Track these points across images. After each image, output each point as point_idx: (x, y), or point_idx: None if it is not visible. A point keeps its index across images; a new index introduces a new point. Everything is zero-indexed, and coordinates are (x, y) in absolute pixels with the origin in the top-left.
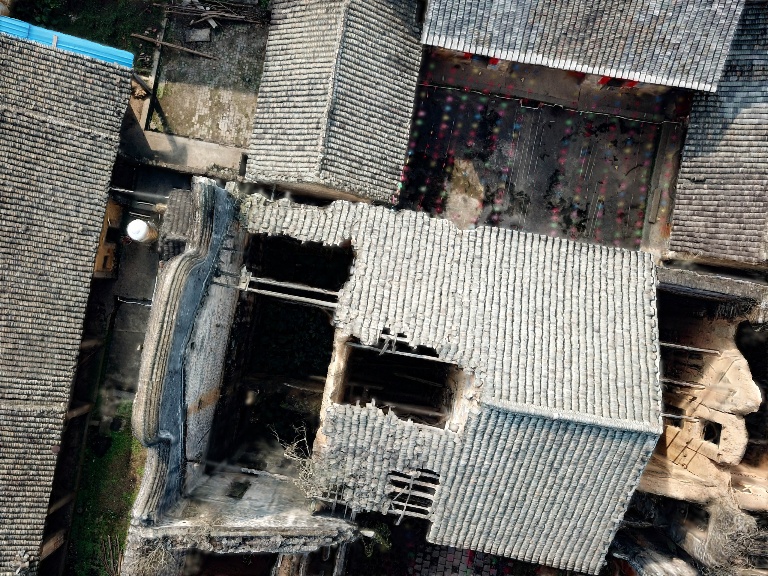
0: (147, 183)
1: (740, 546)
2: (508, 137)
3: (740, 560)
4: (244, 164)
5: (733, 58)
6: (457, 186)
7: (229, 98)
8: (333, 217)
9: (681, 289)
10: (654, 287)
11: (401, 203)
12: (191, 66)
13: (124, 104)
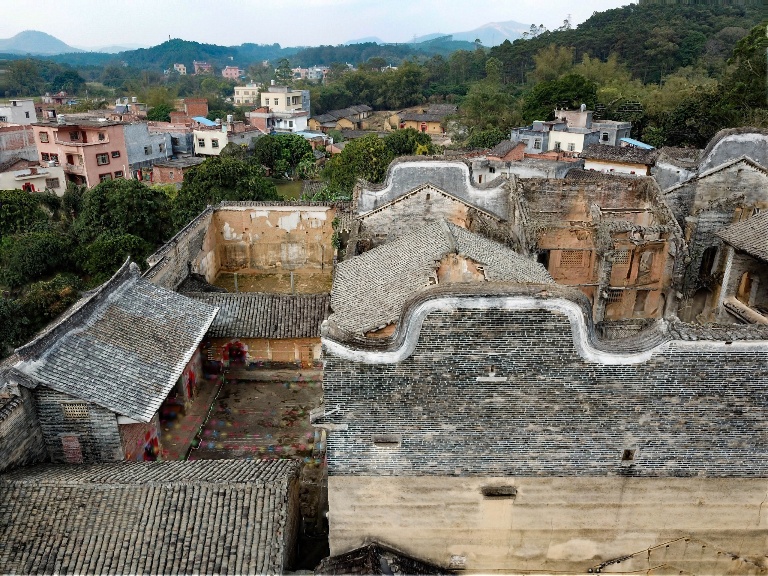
0: None
1: None
2: (226, 454)
3: None
4: None
5: None
6: None
7: None
8: None
9: None
10: None
11: None
12: None
13: None
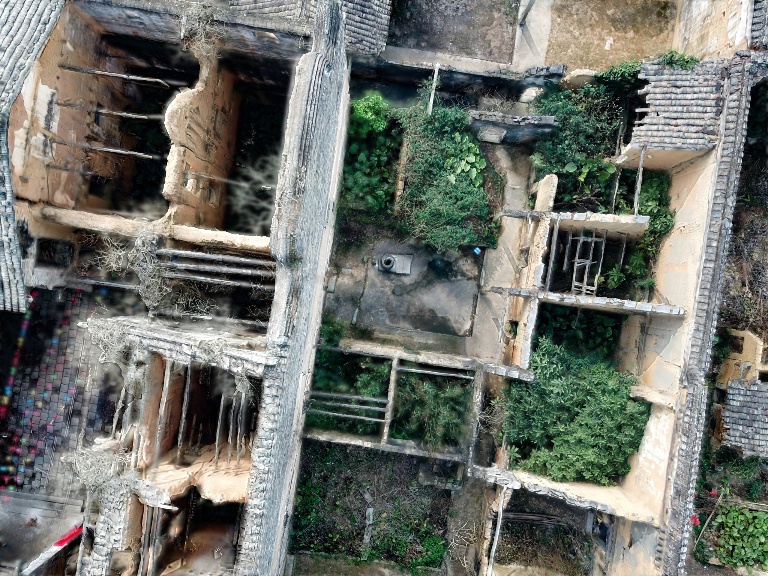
0: None
1: (148, 266)
2: None
3: (154, 283)
4: None
5: None
6: None
7: None
8: None
9: (136, 23)
10: (61, 0)
11: None
12: None
13: None
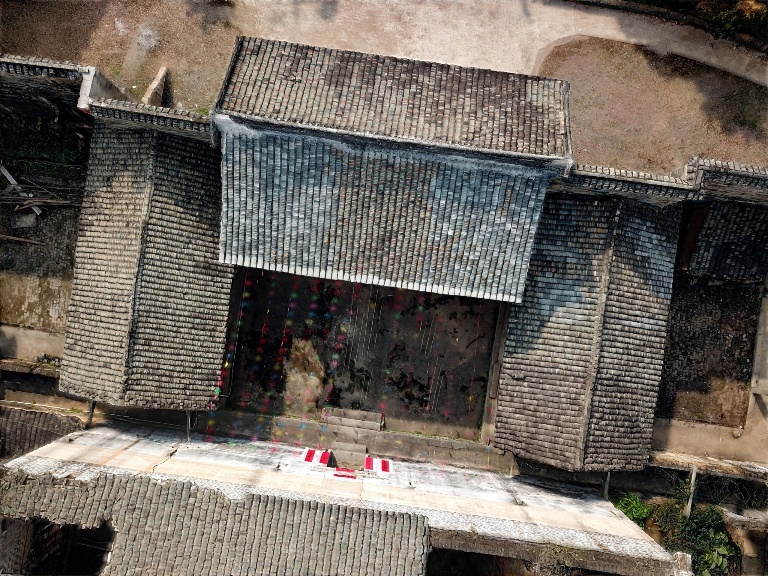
0: None
1: None
2: (346, 313)
3: None
4: None
5: (549, 253)
6: (296, 365)
7: (59, 284)
8: (95, 495)
9: None
10: (424, 557)
11: (240, 384)
12: (18, 252)
13: None
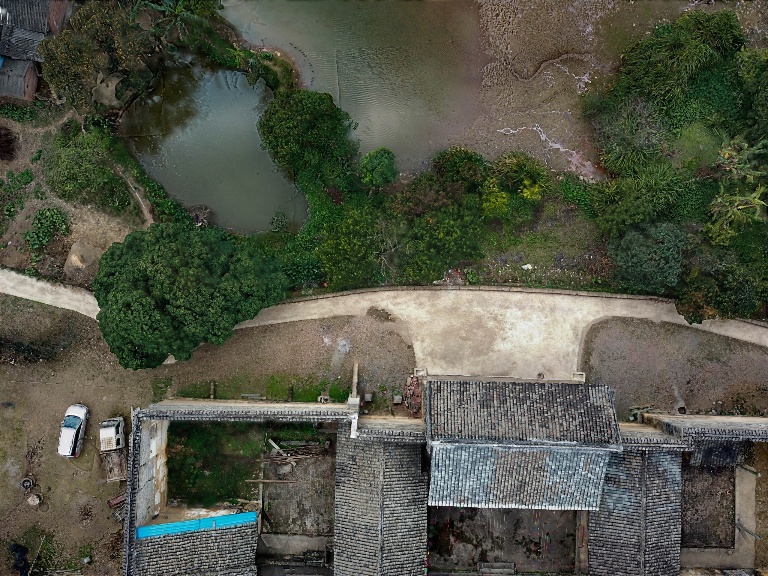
0: (267, 568)
1: None
2: None
3: None
4: (328, 556)
5: (609, 472)
6: (458, 538)
7: (309, 505)
8: None
9: None
10: None
11: None
12: (283, 488)
13: (255, 544)
